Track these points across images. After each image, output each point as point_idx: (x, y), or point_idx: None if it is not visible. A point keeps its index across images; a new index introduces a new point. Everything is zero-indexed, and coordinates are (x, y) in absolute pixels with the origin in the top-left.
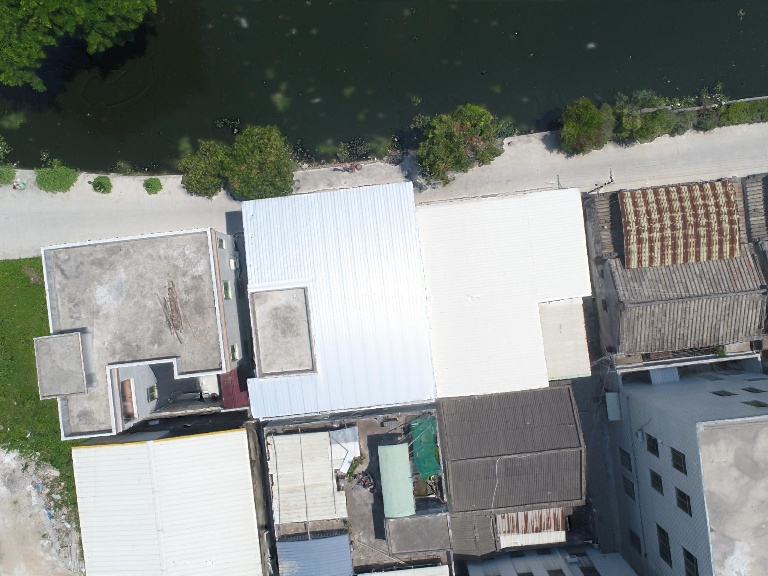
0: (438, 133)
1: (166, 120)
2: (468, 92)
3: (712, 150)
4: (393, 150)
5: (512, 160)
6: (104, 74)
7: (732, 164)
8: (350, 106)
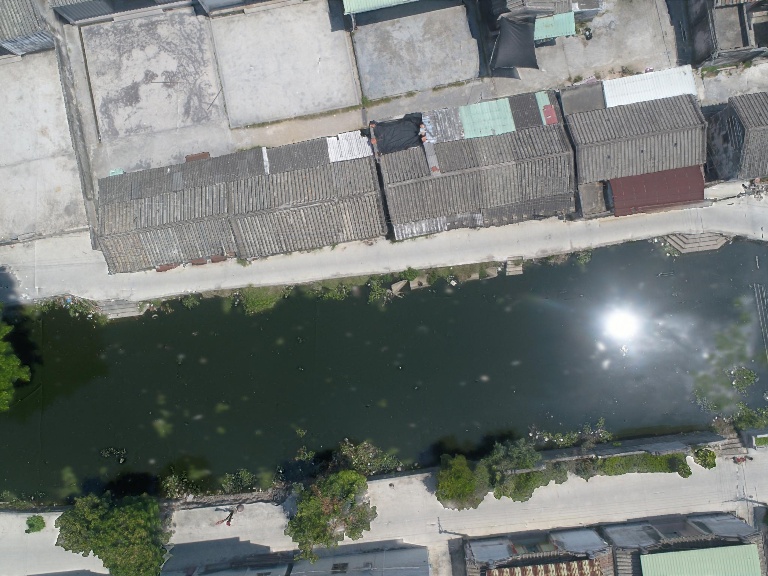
0: (306, 514)
1: (53, 448)
2: (353, 424)
3: (592, 494)
4: (278, 482)
5: (393, 501)
6: None
7: (611, 508)
8: (235, 437)
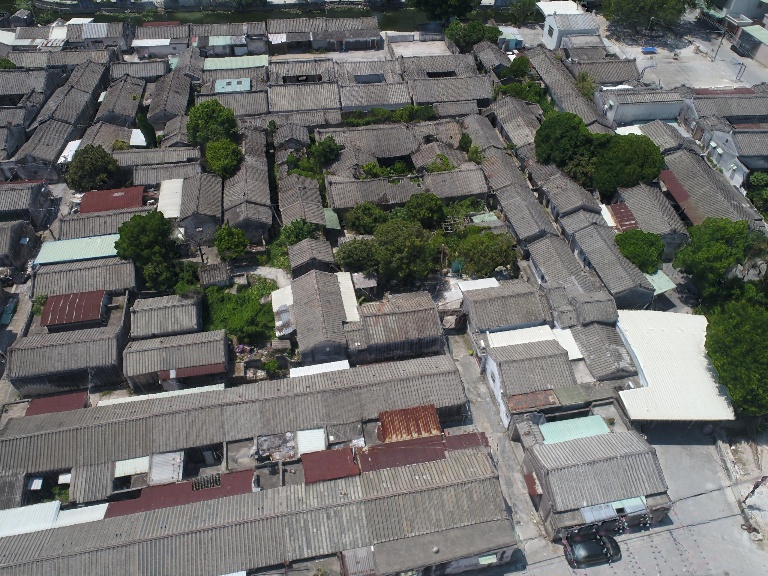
0: None
1: None
2: None
3: None
4: None
5: None
6: (434, 22)
7: None
8: None
